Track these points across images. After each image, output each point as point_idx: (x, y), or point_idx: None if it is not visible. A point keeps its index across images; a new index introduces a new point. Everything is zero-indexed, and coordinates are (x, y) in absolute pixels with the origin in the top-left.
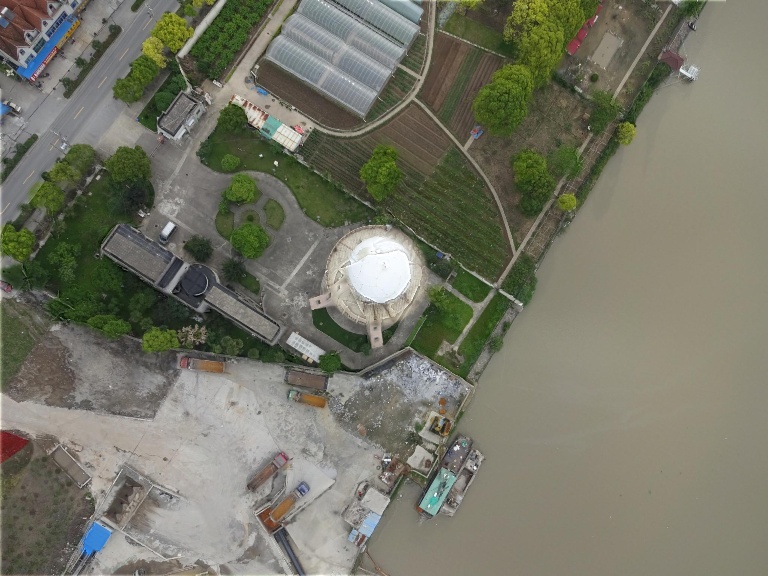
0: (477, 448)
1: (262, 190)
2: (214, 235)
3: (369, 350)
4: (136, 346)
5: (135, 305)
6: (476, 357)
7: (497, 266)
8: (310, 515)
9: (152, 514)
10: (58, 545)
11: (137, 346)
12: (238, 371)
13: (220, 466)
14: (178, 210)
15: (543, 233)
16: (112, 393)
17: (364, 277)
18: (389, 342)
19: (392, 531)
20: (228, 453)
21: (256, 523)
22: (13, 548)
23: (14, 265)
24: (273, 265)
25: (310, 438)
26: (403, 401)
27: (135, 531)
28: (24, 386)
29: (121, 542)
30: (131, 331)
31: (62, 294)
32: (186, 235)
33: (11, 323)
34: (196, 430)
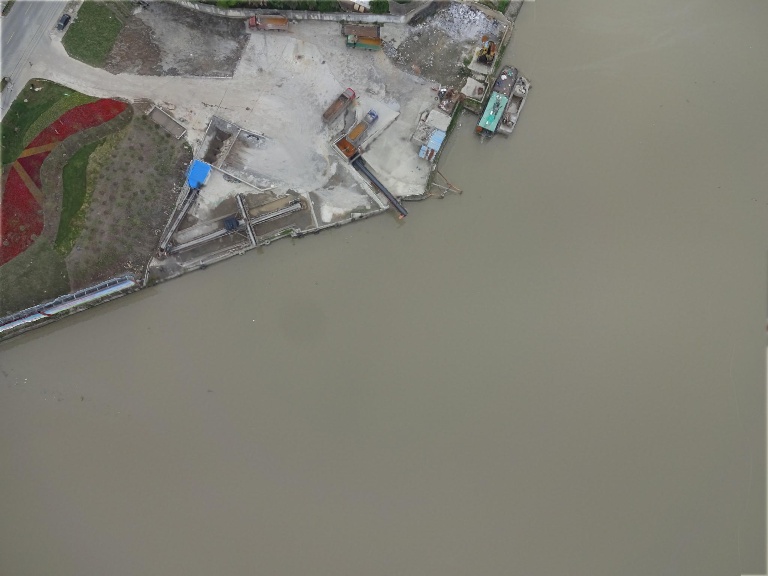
0: (522, 75)
1: None
2: None
3: (412, 1)
4: (208, 19)
5: None
6: None
7: None
8: (382, 143)
9: (243, 153)
10: (166, 185)
11: (209, 19)
12: (300, 30)
13: (296, 110)
14: None
15: None
16: (194, 60)
17: None
18: None
19: (457, 156)
20: (301, 99)
21: (335, 155)
22: (129, 188)
23: None
24: None
25: (372, 80)
26: (449, 42)
27: (231, 169)
28: (118, 61)
29: (220, 181)
30: None
31: None
32: None
33: (100, 10)
34: (271, 83)
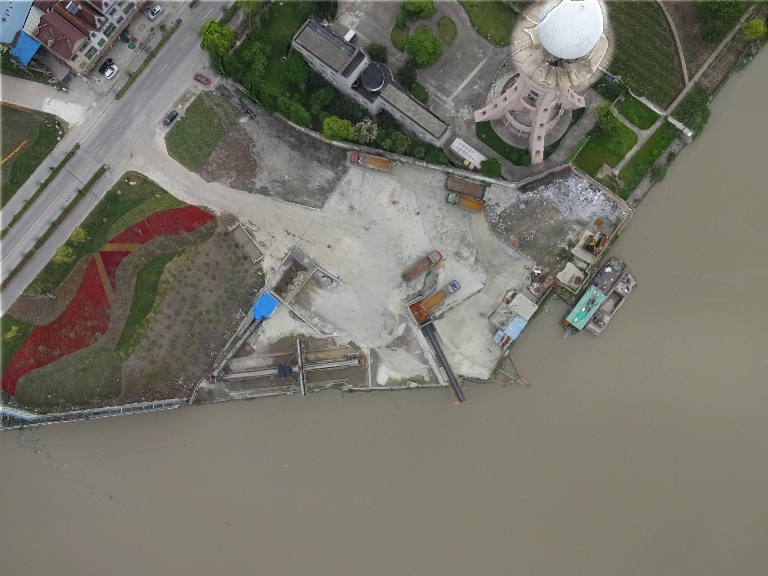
0: (630, 272)
1: (437, 7)
2: (389, 47)
3: None
4: (311, 142)
5: (315, 100)
6: (637, 182)
7: (667, 94)
8: (458, 314)
9: (314, 294)
10: (232, 310)
11: (312, 142)
12: (401, 173)
13: (378, 259)
14: (358, 22)
15: (720, 65)
16: (287, 183)
17: (559, 20)
18: (549, 159)
19: (535, 343)
20: (386, 248)
21: (406, 315)
22: (196, 305)
23: (213, 63)
24: (442, 78)
25: (464, 243)
26: (558, 218)
27: (298, 307)
28: (214, 169)
29: (285, 316)
30: (310, 123)
31: (252, 88)
32: (364, 44)
33: (207, 112)
34: (359, 223)
